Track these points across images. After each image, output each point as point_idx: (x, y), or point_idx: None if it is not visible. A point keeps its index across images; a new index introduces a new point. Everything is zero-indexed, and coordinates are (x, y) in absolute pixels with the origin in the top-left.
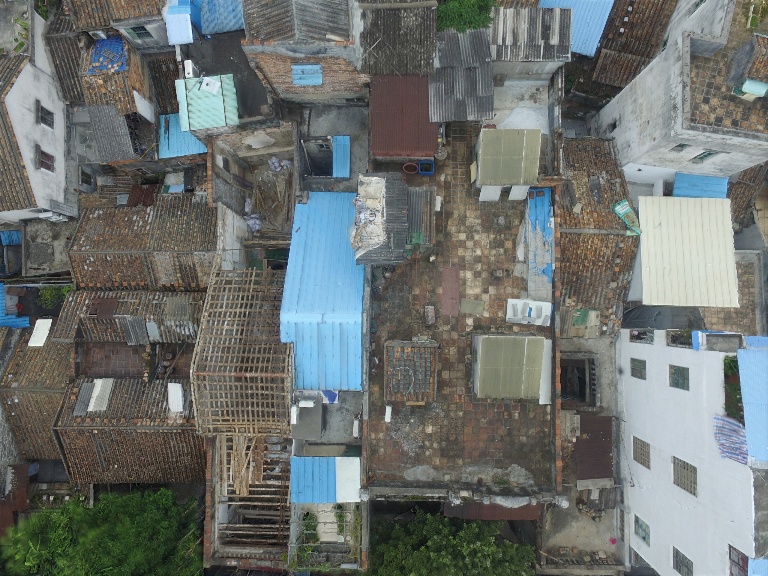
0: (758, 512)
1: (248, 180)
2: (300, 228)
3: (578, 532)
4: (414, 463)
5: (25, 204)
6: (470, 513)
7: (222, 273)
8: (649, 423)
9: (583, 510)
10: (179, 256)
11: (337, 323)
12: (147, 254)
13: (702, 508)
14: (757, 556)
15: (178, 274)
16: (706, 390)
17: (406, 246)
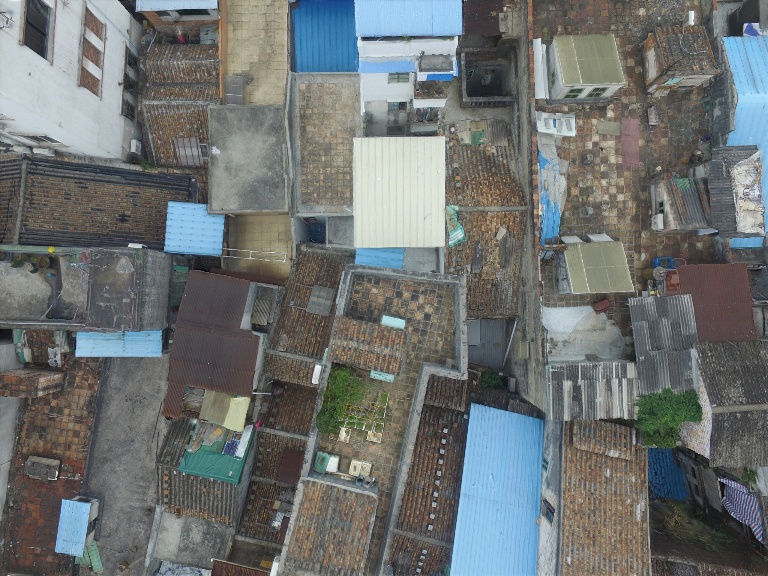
0: None
1: None
2: None
3: None
4: None
5: None
6: None
7: None
8: None
9: None
10: None
11: (762, 93)
12: None
13: None
14: None
15: None
16: None
17: None
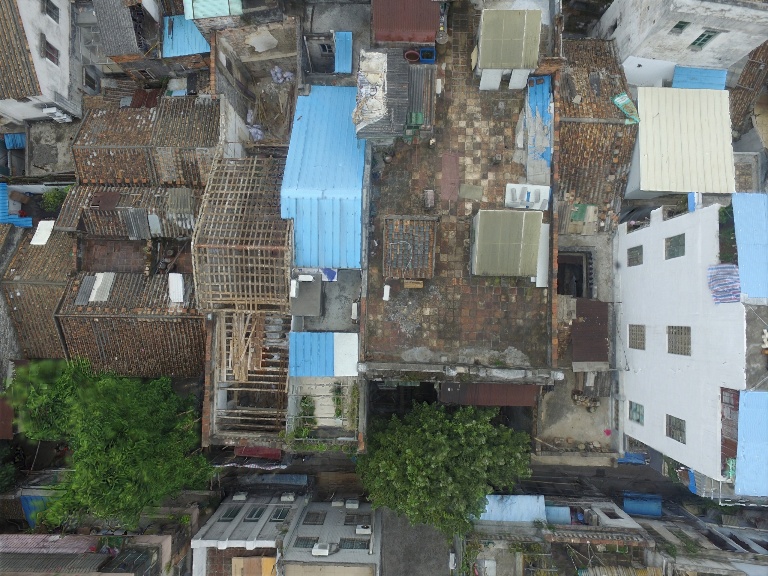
0: (750, 345)
1: (251, 92)
2: (302, 117)
3: (573, 423)
4: (411, 344)
5: (30, 91)
6: (466, 398)
7: (224, 160)
8: (645, 304)
9: (578, 400)
10: (181, 152)
11: (337, 199)
12: (150, 149)
13: (695, 363)
14: (748, 387)
15: (180, 171)
16: (701, 247)
17: (406, 131)
